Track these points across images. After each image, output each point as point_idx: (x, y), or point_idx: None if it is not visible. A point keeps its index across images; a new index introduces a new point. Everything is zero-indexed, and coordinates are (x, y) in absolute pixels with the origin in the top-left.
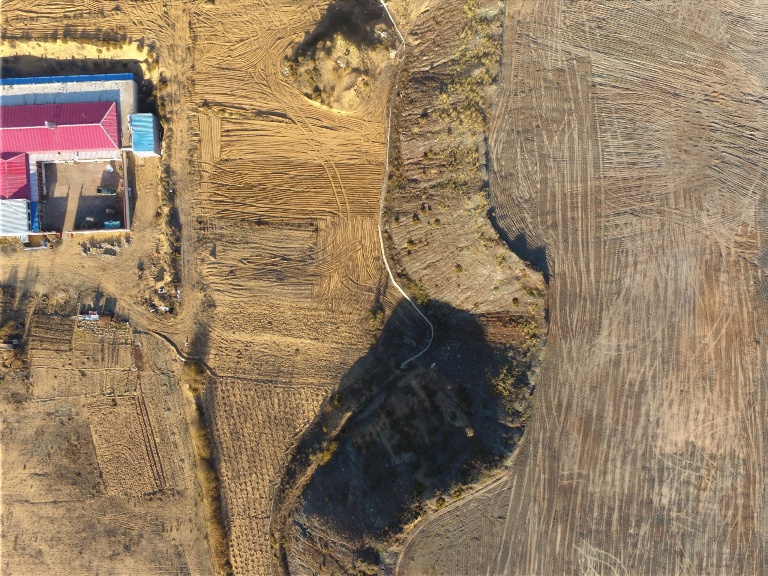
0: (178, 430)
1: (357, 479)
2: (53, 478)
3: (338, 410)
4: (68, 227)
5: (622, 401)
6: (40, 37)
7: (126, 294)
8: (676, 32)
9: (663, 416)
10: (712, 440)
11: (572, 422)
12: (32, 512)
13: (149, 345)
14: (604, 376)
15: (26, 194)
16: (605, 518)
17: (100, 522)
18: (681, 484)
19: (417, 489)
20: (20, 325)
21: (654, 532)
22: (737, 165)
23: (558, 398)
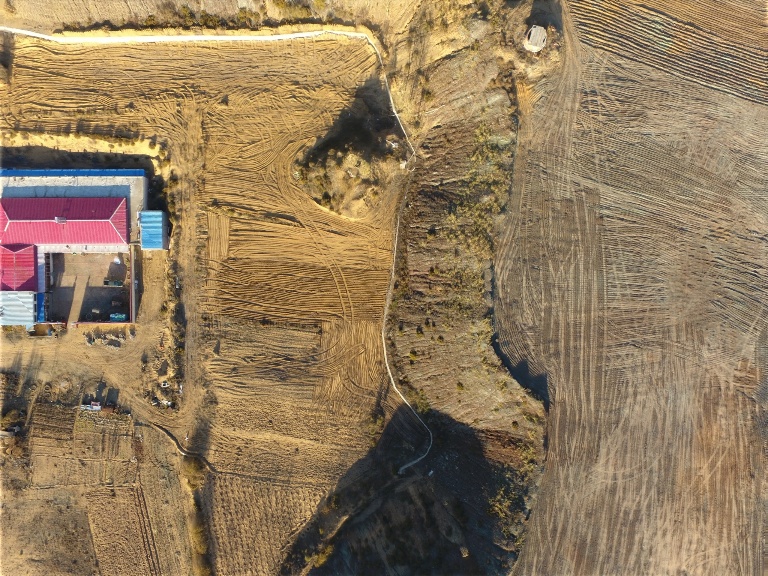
0: (175, 523)
1: None
2: (49, 565)
3: (335, 512)
4: (73, 317)
5: (616, 529)
6: (53, 130)
7: (129, 386)
8: (685, 168)
9: (656, 545)
10: (703, 570)
11: (566, 547)
12: None
13: (150, 438)
14: (600, 503)
15: (33, 286)
16: None
17: None
18: None
19: None
20: (22, 412)
21: None
22: (739, 301)
23: (553, 523)
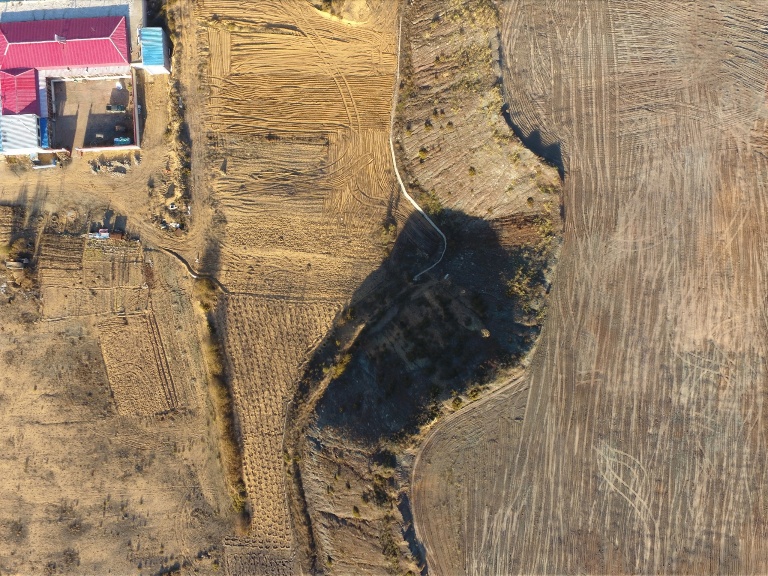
0: (190, 348)
1: (371, 388)
2: (64, 398)
3: (351, 323)
4: (78, 145)
5: (639, 299)
6: None
7: (136, 212)
8: None
9: (681, 314)
10: (731, 338)
11: (589, 321)
12: (43, 433)
13: (160, 262)
14: (621, 274)
15: (36, 110)
16: (623, 418)
17: (112, 443)
18: (700, 383)
19: (433, 391)
20: (30, 244)
21: (673, 432)
22: (752, 59)
23: (574, 297)
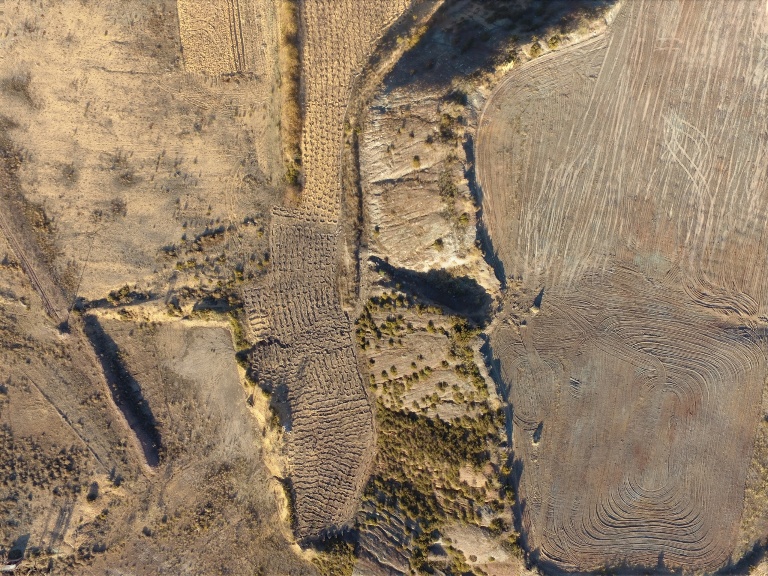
0: (265, 13)
1: (446, 51)
2: (133, 47)
3: (430, 0)
4: None
5: None
6: None
7: None
8: None
9: None
10: None
11: None
12: (107, 80)
13: None
14: None
15: None
16: (696, 90)
17: (174, 98)
18: None
19: (513, 37)
20: None
21: (742, 111)
22: None
23: None
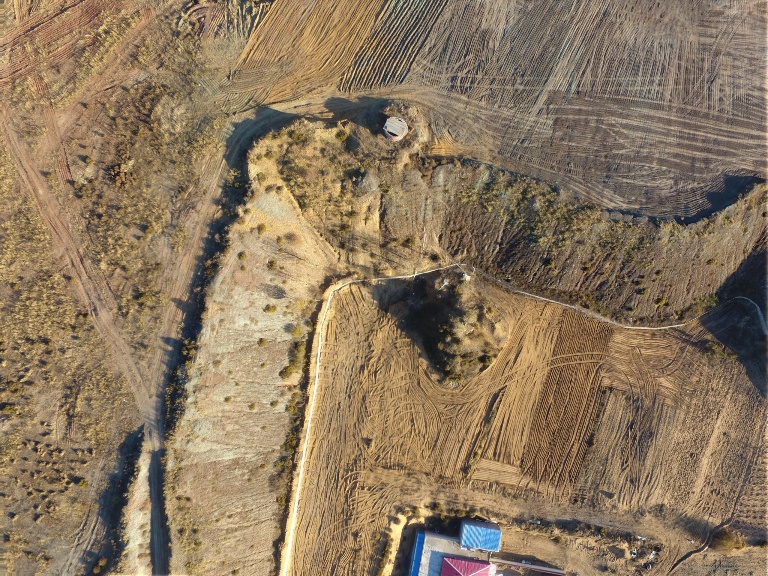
0: None
1: None
2: None
3: None
4: None
5: None
6: None
7: None
8: (544, 1)
9: None
10: None
11: None
12: None
13: None
14: None
15: None
16: None
17: None
18: None
19: None
20: None
21: None
22: None
23: None
